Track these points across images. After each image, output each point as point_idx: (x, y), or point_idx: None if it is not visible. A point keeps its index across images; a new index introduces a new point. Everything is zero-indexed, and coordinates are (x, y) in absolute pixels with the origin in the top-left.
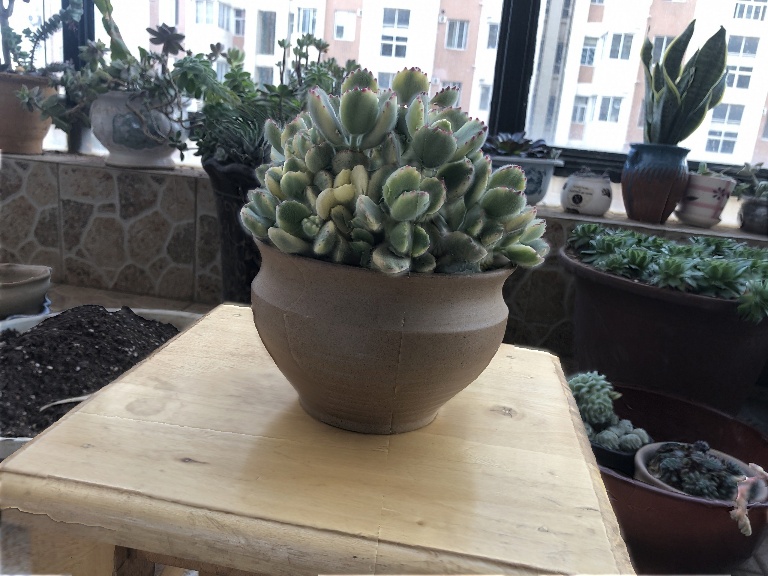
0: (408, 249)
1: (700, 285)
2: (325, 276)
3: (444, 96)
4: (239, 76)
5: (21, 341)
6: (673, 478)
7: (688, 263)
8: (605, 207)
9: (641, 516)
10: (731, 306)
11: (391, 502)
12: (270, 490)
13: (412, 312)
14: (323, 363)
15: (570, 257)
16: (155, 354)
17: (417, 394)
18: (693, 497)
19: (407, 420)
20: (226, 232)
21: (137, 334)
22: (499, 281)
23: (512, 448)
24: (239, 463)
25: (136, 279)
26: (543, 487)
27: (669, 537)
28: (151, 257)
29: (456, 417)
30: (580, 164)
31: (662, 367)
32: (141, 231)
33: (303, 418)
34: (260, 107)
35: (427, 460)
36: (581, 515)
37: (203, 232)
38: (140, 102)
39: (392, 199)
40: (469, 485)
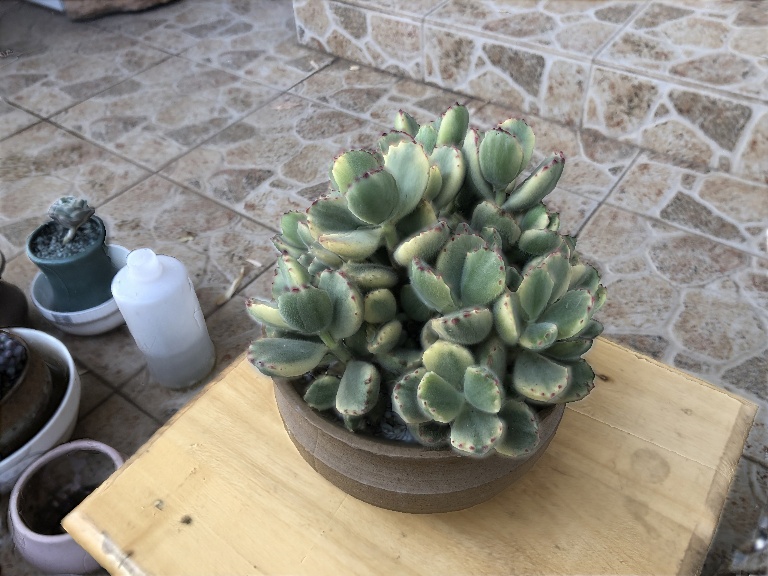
0: None
1: None
2: None
3: None
4: None
5: None
6: None
7: None
8: None
9: None
10: None
11: None
12: None
13: None
14: None
15: None
16: None
17: None
18: None
19: None
20: None
21: None
22: None
23: None
24: None
25: None
26: None
27: None
28: None
29: None
30: None
31: None
32: None
33: None
34: None
35: None
36: None
37: None
38: None
39: None
40: None
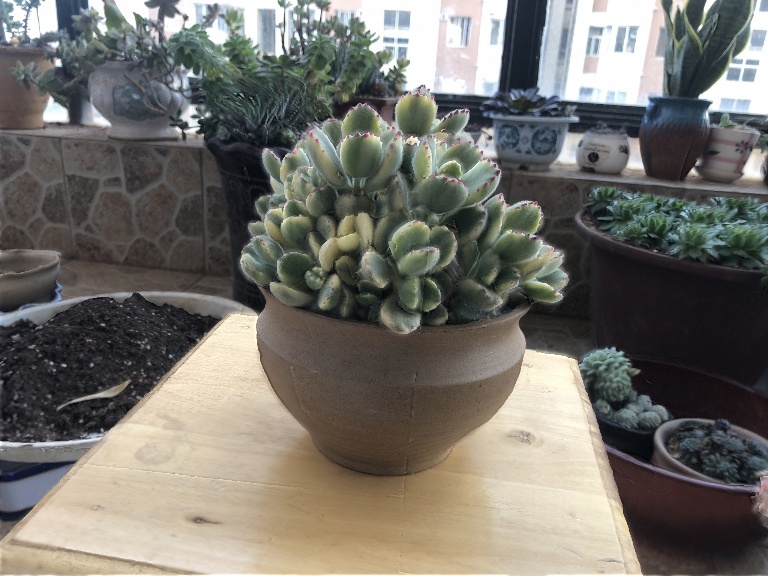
0: (418, 305)
1: (722, 255)
2: (332, 331)
3: (453, 121)
4: (238, 45)
5: (33, 339)
6: (693, 460)
7: (710, 233)
8: (622, 164)
9: (660, 499)
10: (754, 277)
11: (408, 563)
12: (284, 554)
13: (424, 366)
14: (333, 417)
15: (586, 224)
16: (163, 383)
17: (432, 440)
18: (714, 483)
19: (422, 460)
20: (233, 212)
21: (149, 325)
22: (515, 322)
23: (531, 485)
24: (252, 521)
25: (146, 253)
26: (564, 534)
27: (689, 520)
28: (160, 230)
29: (473, 448)
30: (596, 119)
31: (681, 338)
32: (148, 204)
33: (316, 458)
34: (262, 79)
35: (444, 506)
36: (604, 570)
37: (211, 204)
38: (139, 72)
39: (400, 255)
40: (488, 536)
